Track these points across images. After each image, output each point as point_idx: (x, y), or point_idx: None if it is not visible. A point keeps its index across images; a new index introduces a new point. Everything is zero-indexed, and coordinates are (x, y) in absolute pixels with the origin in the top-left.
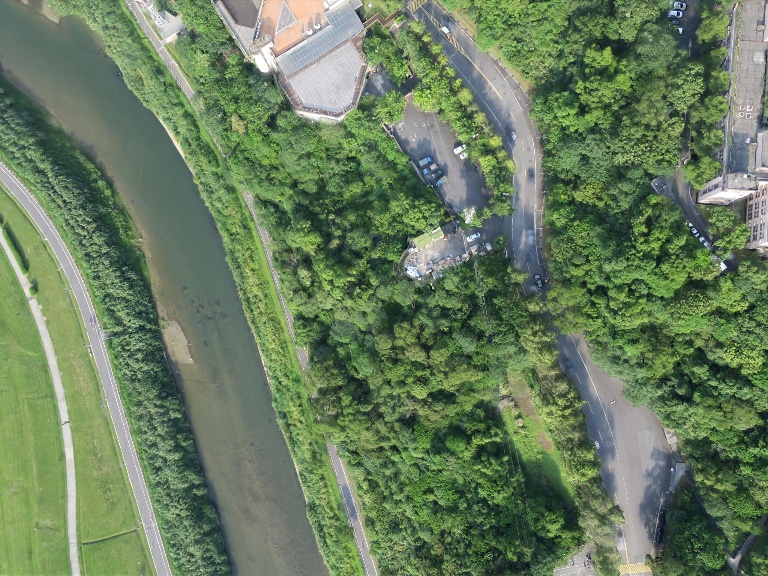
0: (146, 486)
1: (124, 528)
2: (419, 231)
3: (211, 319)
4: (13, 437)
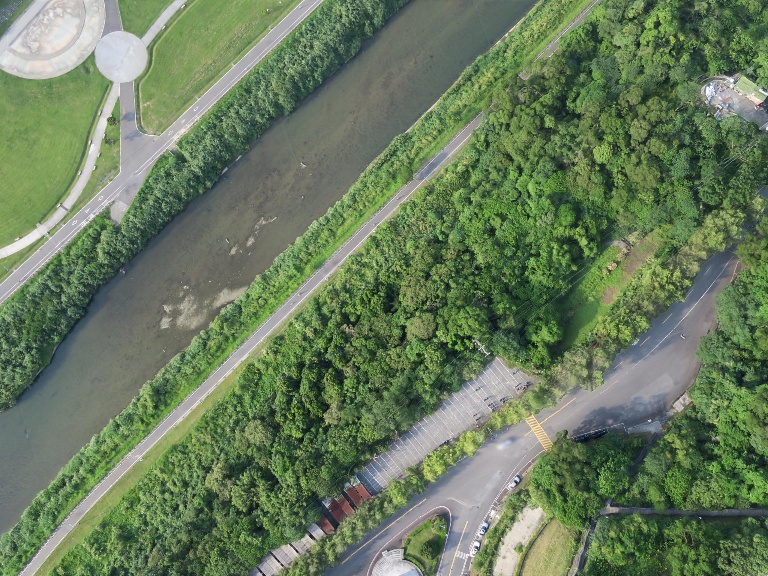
0: None
1: None
2: (754, 78)
3: None
4: None
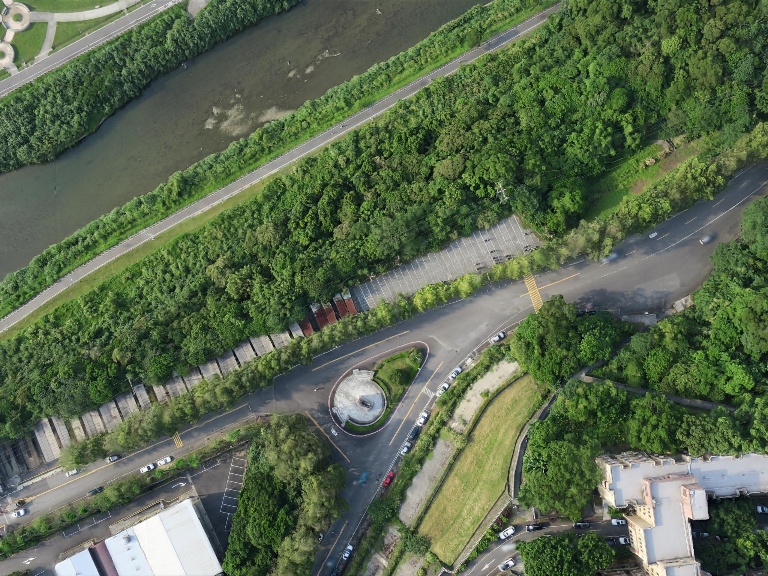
0: None
1: None
2: None
3: None
4: None
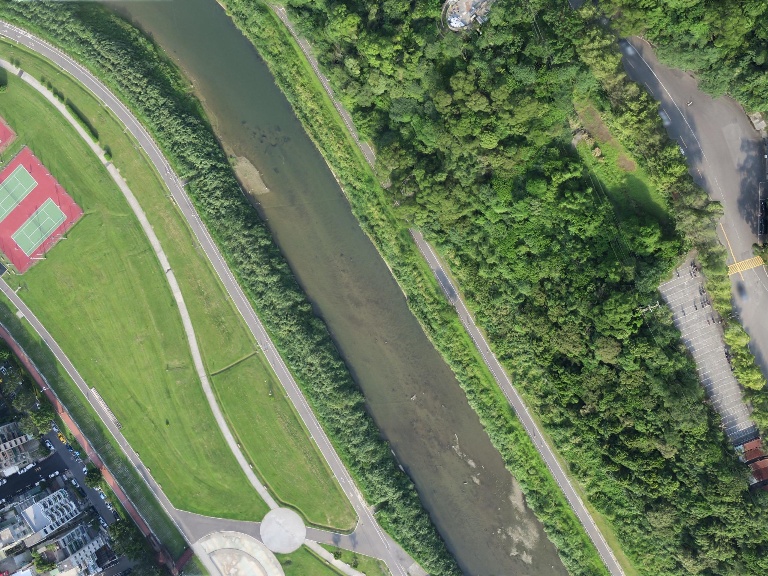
0: (254, 312)
1: (244, 353)
2: None
3: (275, 146)
4: (126, 294)
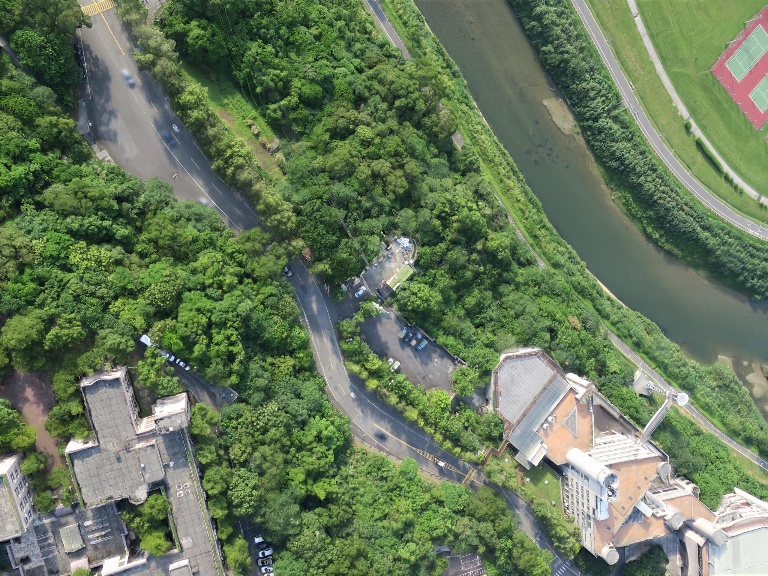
0: None
1: None
2: None
3: (538, 146)
4: None
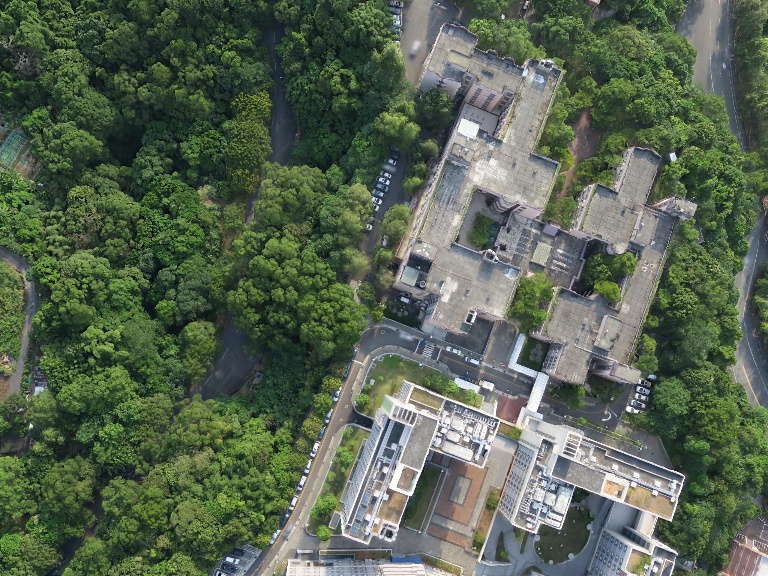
0: None
1: None
2: None
3: None
4: None
